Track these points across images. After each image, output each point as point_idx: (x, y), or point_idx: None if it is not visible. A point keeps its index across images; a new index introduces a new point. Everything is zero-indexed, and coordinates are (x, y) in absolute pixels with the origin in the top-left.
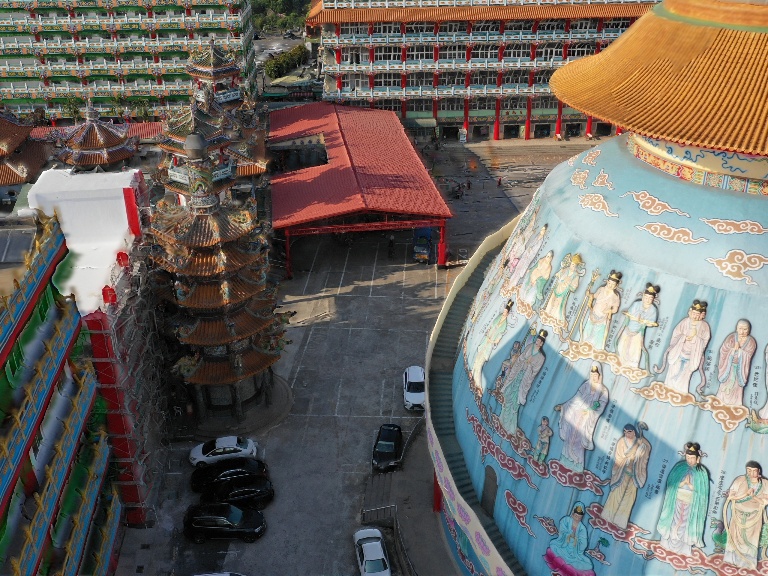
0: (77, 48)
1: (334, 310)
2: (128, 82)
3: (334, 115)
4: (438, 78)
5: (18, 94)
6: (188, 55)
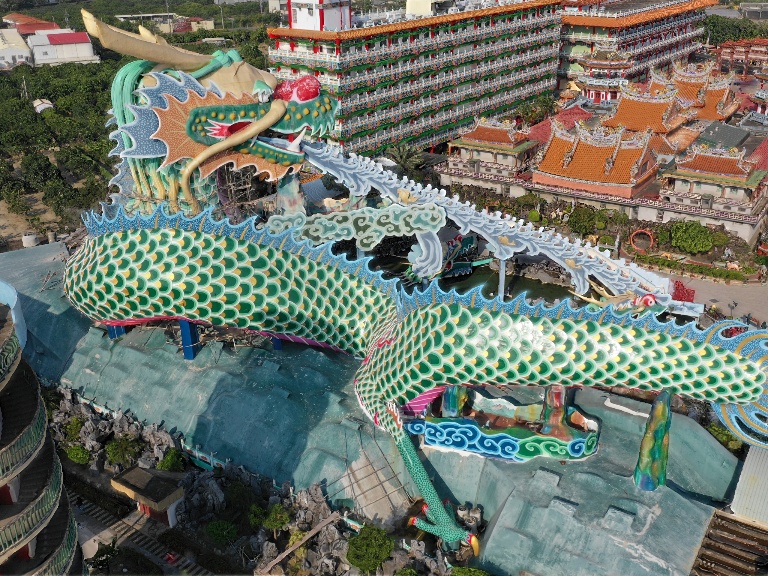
0: (497, 68)
1: None
2: (507, 92)
3: (641, 85)
4: (633, 58)
5: (466, 114)
6: (534, 64)
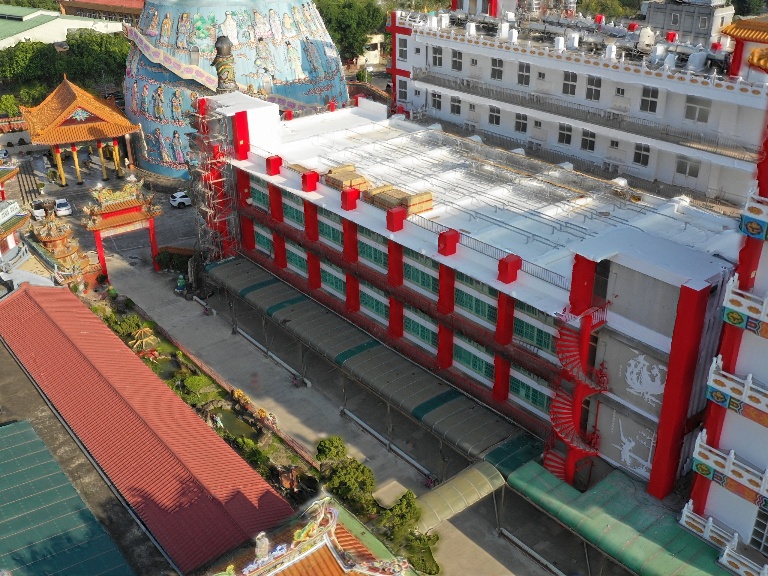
0: None
1: (83, 251)
2: None
3: None
4: None
5: None
6: None
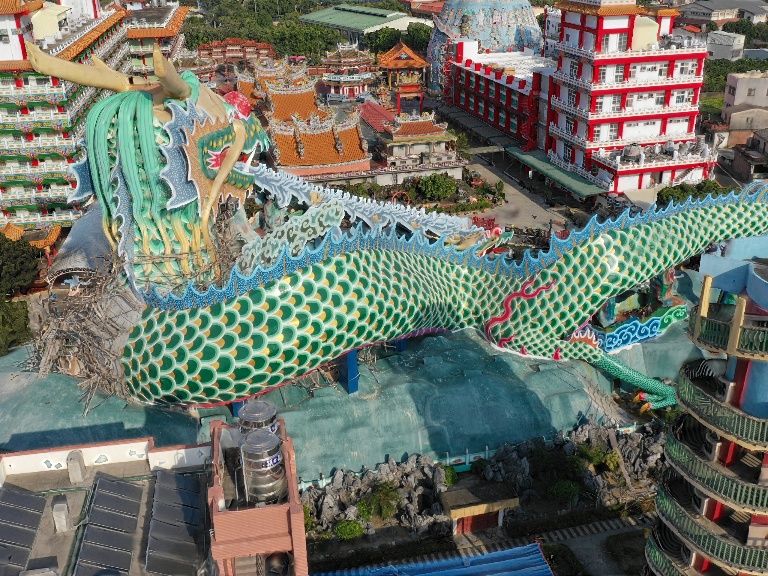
0: None
1: None
2: None
3: None
4: None
5: None
6: None
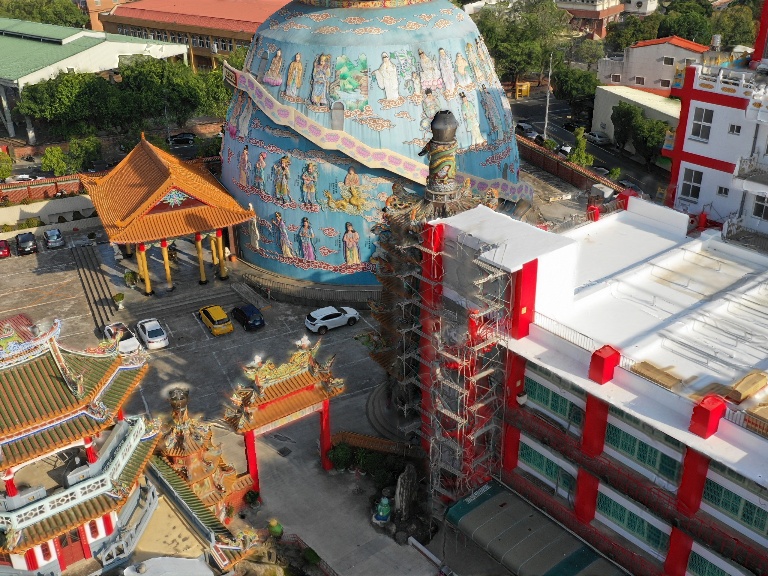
0: None
1: None
2: None
3: None
4: None
5: None
6: None
